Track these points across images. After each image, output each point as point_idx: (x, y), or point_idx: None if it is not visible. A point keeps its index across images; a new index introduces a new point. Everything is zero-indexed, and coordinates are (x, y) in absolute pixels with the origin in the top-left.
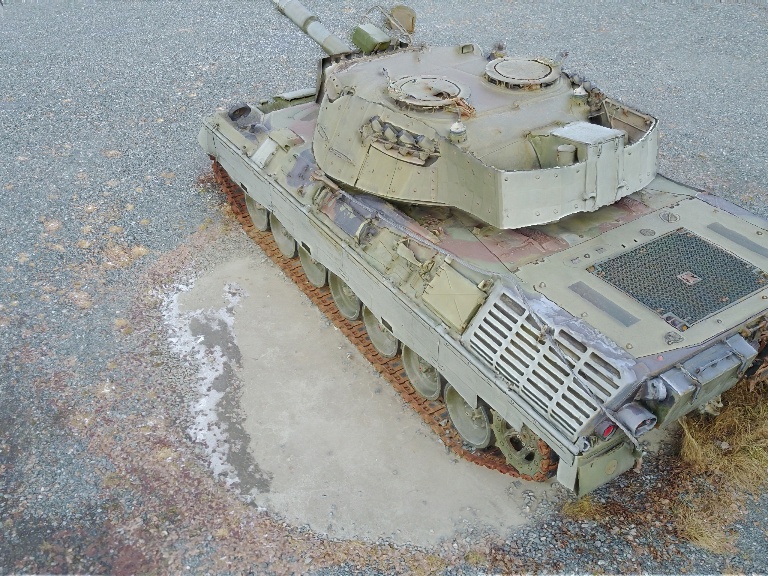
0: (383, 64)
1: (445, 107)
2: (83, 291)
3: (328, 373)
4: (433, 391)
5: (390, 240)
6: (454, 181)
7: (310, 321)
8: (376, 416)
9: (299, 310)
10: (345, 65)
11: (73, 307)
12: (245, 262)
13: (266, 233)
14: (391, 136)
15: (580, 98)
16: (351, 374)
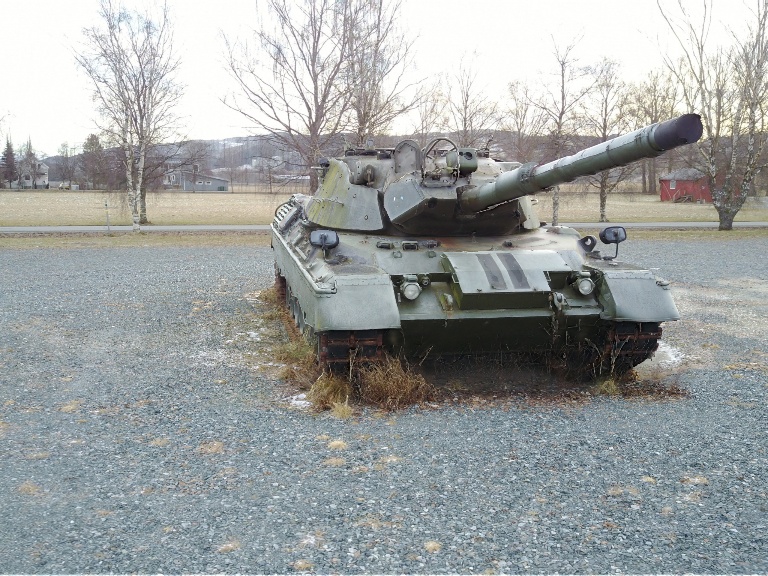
0: None
1: None
2: (767, 356)
3: None
4: None
5: None
6: None
7: None
8: None
9: None
10: None
11: (767, 351)
12: None
13: None
14: None
15: None
16: None
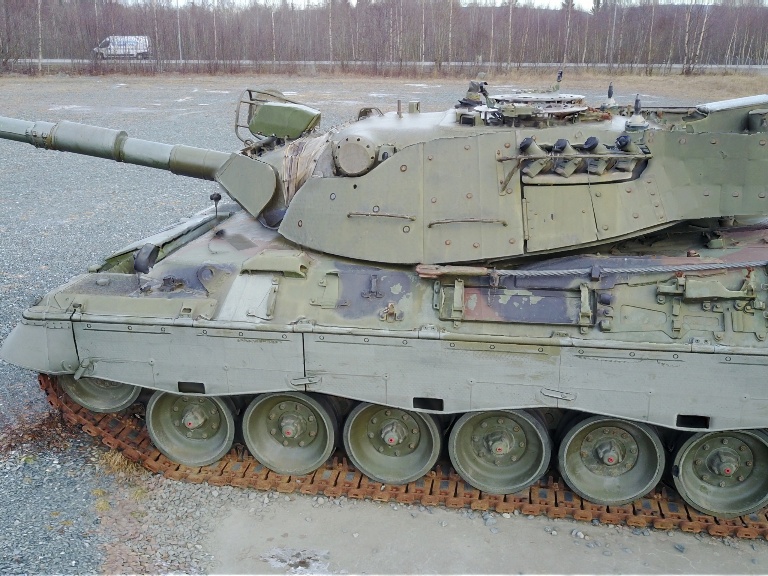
0: (373, 124)
1: (579, 115)
2: None
3: (600, 570)
4: (747, 497)
5: (641, 296)
6: (682, 184)
7: (463, 529)
8: (734, 575)
9: (425, 526)
10: (296, 146)
11: None
12: (240, 517)
13: (217, 465)
14: (573, 153)
15: (617, 109)
16: (621, 552)
